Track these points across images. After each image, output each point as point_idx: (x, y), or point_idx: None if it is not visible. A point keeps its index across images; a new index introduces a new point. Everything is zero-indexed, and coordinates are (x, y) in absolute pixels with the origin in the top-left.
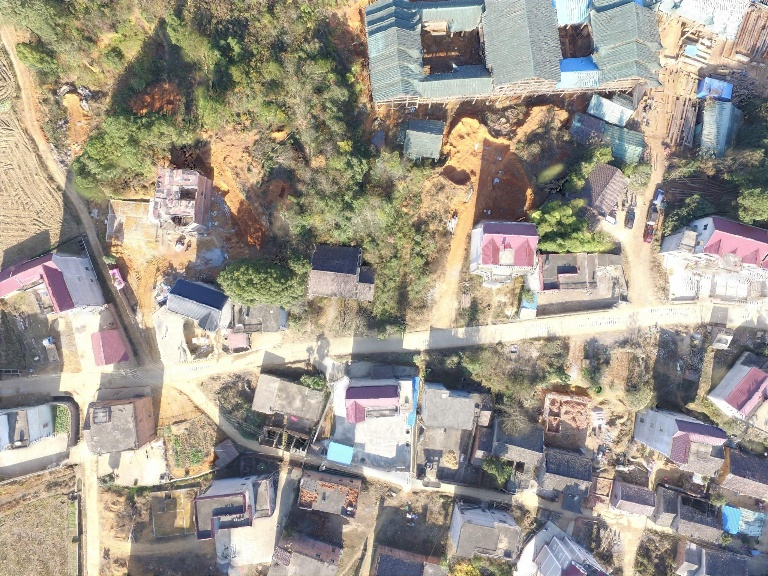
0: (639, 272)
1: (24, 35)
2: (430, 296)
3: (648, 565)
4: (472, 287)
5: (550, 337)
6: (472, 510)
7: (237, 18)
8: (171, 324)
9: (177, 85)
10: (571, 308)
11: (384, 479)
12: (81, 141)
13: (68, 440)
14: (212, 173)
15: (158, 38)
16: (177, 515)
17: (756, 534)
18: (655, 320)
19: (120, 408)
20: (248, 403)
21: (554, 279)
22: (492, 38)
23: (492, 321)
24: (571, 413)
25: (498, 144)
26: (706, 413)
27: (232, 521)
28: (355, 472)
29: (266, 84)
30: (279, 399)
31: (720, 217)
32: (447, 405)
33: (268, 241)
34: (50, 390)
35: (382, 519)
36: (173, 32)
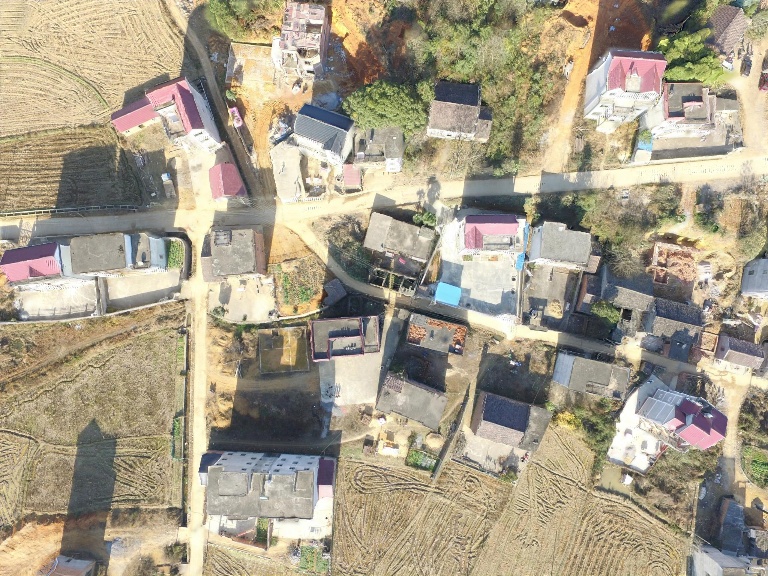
0: (754, 120)
1: None
2: (543, 141)
3: (754, 420)
4: (586, 131)
5: (662, 183)
6: (578, 356)
7: None
8: (288, 159)
9: None
10: (684, 154)
11: (488, 326)
12: None
13: (181, 273)
14: (330, 20)
15: None
16: (284, 352)
17: None
18: None
19: (240, 232)
20: (359, 242)
21: (678, 108)
22: None
23: (604, 167)
24: (678, 265)
25: None
26: None
27: (344, 350)
28: (460, 318)
29: None
30: (390, 237)
31: None
32: (563, 238)
33: None
34: (165, 226)
35: (485, 366)
36: None
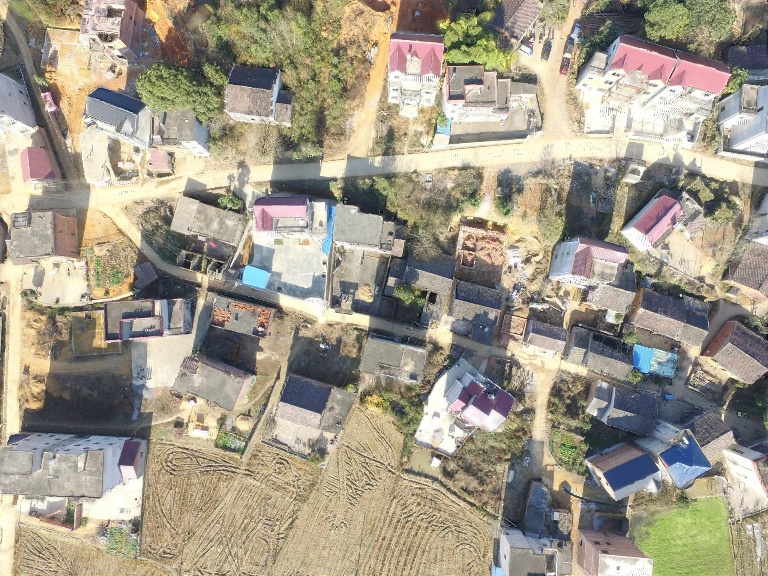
0: (554, 105)
1: None
2: (348, 125)
3: (559, 403)
4: (389, 116)
5: (464, 167)
6: (383, 339)
7: None
8: (96, 143)
9: None
10: (486, 138)
11: (300, 309)
12: None
13: None
14: (145, 6)
15: None
16: (96, 335)
17: (669, 375)
18: (569, 153)
19: (40, 215)
20: (168, 225)
21: (460, 91)
22: None
23: (408, 151)
24: (486, 249)
25: None
26: None
27: (143, 331)
28: (271, 301)
29: None
30: (197, 221)
31: (628, 35)
32: (355, 220)
33: (193, 66)
34: None
35: (296, 349)
36: None
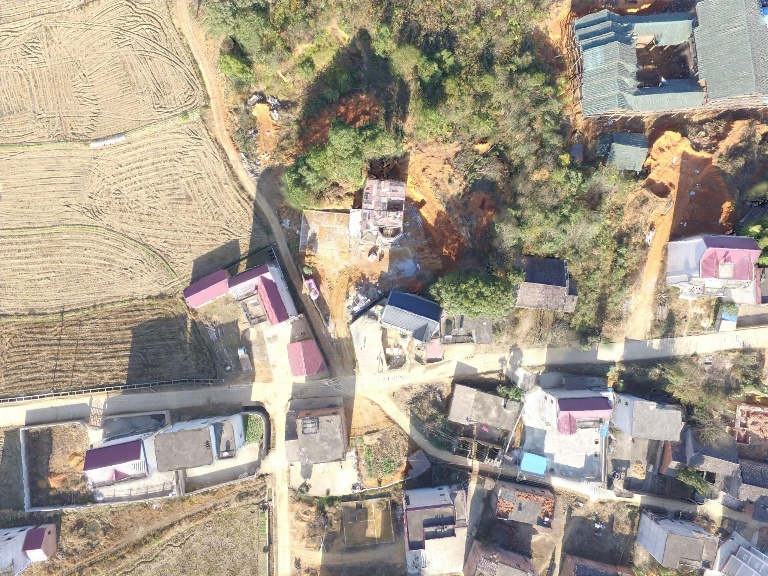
0: None
1: (215, 44)
2: (625, 307)
3: None
4: (669, 299)
5: (745, 349)
6: (663, 520)
7: (447, 30)
8: (370, 335)
9: (375, 96)
10: (767, 320)
11: (572, 489)
12: (270, 151)
13: (261, 450)
14: None
15: (352, 49)
16: (368, 525)
17: None
18: None
19: (328, 419)
20: (443, 413)
21: None
22: (706, 53)
23: (687, 333)
24: (759, 424)
25: (697, 157)
26: None
27: (435, 531)
28: (543, 482)
29: (477, 96)
30: (475, 410)
31: None
32: (654, 417)
33: (467, 252)
34: (242, 400)
35: (569, 529)
36: (383, 44)
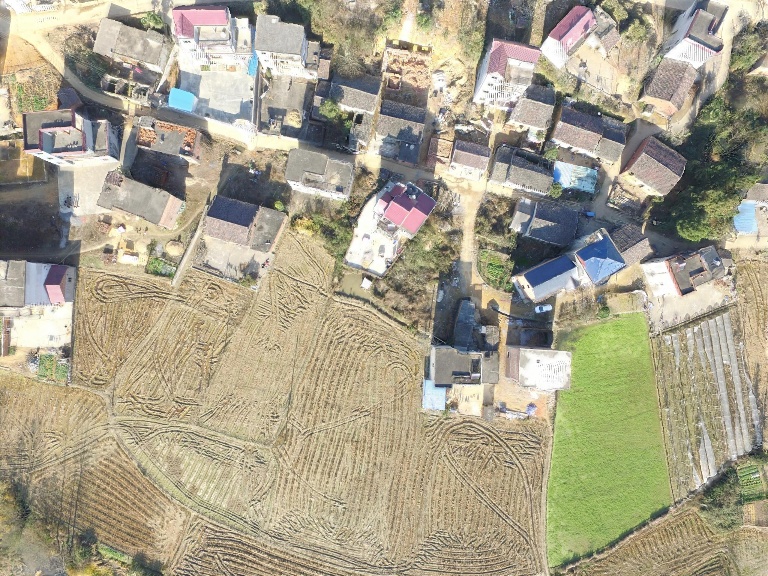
0: None
1: None
2: None
3: (485, 221)
4: None
5: None
6: None
7: None
8: None
9: None
10: None
11: (229, 136)
12: None
13: None
14: None
15: None
16: (20, 163)
17: (589, 190)
18: None
19: None
20: (91, 49)
21: None
22: None
23: None
24: (411, 72)
25: None
26: (542, 73)
27: (66, 148)
28: (200, 128)
29: None
30: (121, 43)
31: None
32: (277, 30)
33: None
34: None
35: (226, 176)
36: None
